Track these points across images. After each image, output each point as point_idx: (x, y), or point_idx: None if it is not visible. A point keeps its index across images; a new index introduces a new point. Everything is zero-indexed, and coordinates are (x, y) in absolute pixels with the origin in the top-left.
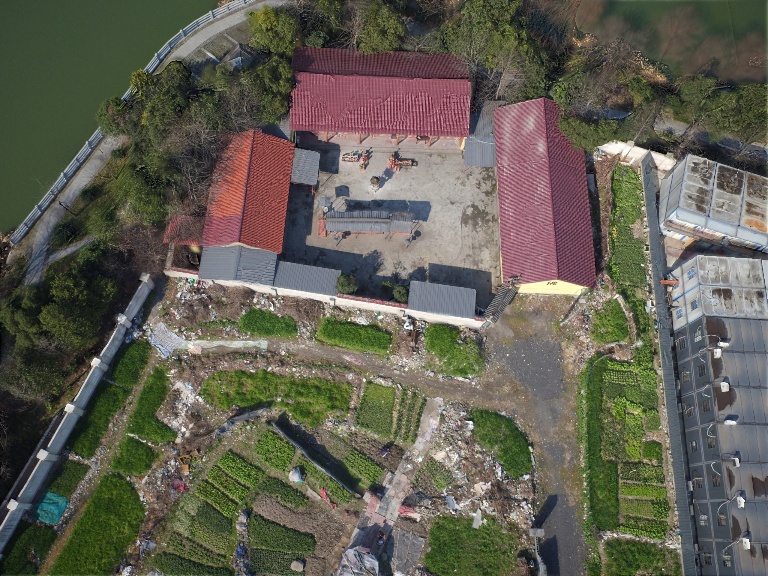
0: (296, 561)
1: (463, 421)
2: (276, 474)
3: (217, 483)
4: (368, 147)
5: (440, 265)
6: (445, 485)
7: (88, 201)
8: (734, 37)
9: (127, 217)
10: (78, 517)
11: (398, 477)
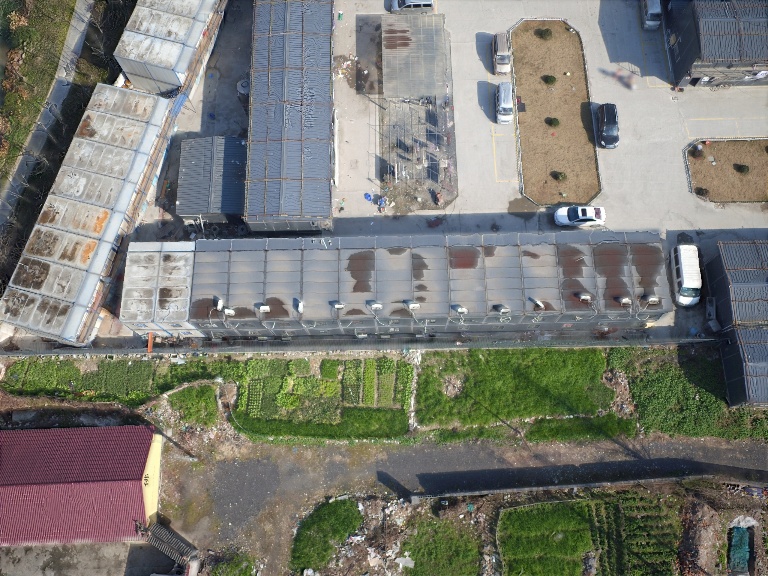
0: None
1: None
2: None
3: None
4: None
5: None
6: None
7: None
8: None
9: None
10: None
11: None
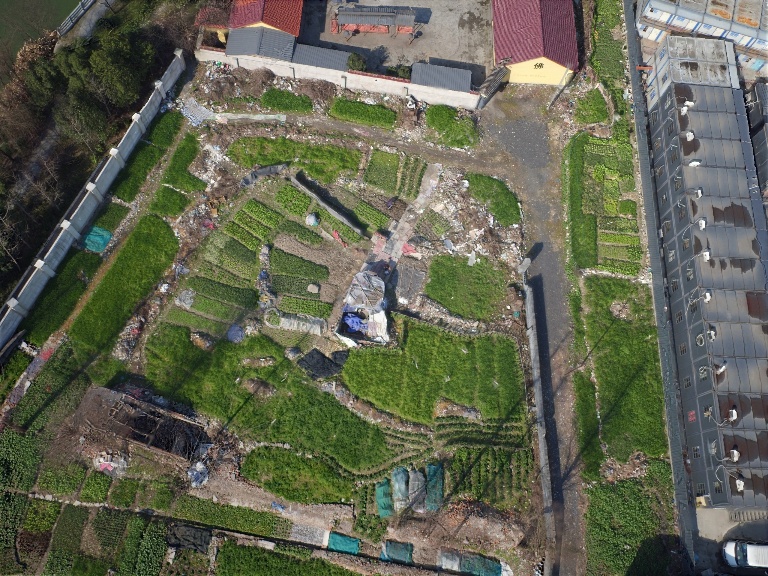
0: (312, 284)
1: (459, 181)
2: (294, 219)
3: (242, 223)
4: None
5: (440, 59)
6: (443, 231)
7: (126, 2)
8: None
9: None
10: (121, 248)
11: (402, 224)
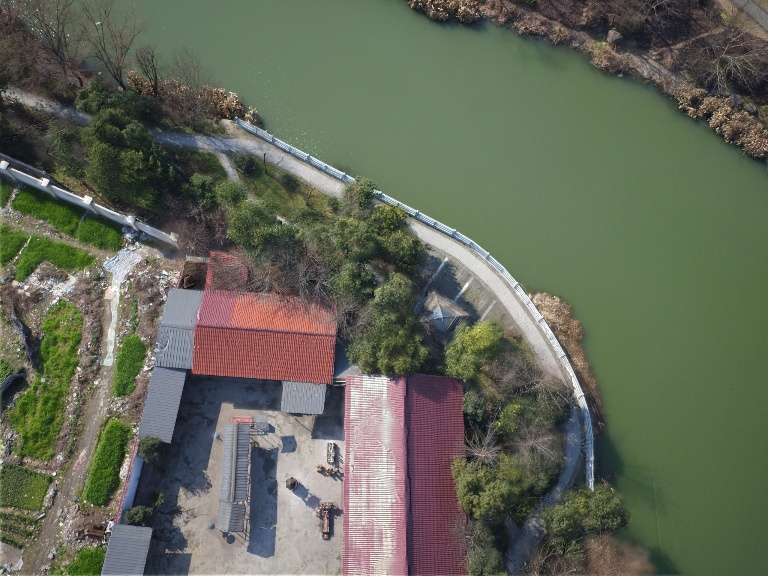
0: None
1: None
2: None
3: None
4: None
5: (188, 569)
6: None
7: None
8: None
9: (233, 214)
10: None
11: None
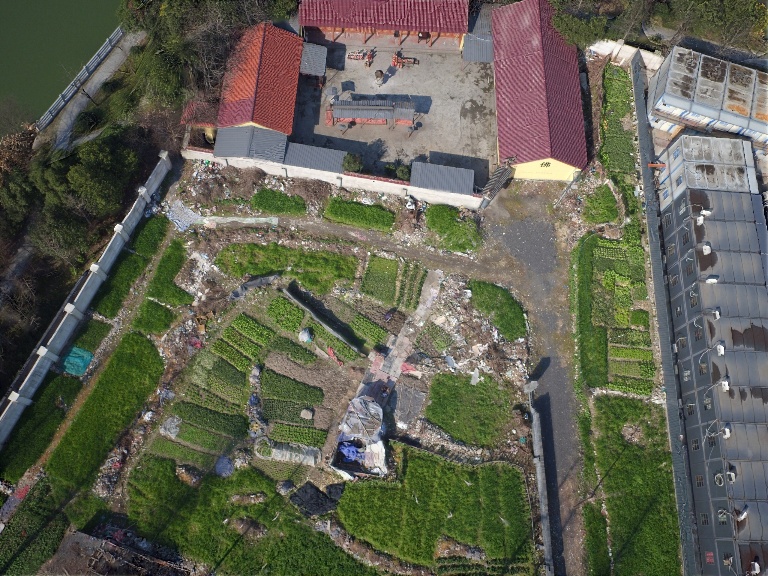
0: (306, 410)
1: (462, 290)
2: (287, 335)
3: (231, 341)
4: (372, 47)
5: (440, 153)
6: (445, 347)
7: (109, 93)
8: None
9: (147, 98)
10: (102, 370)
11: (401, 339)
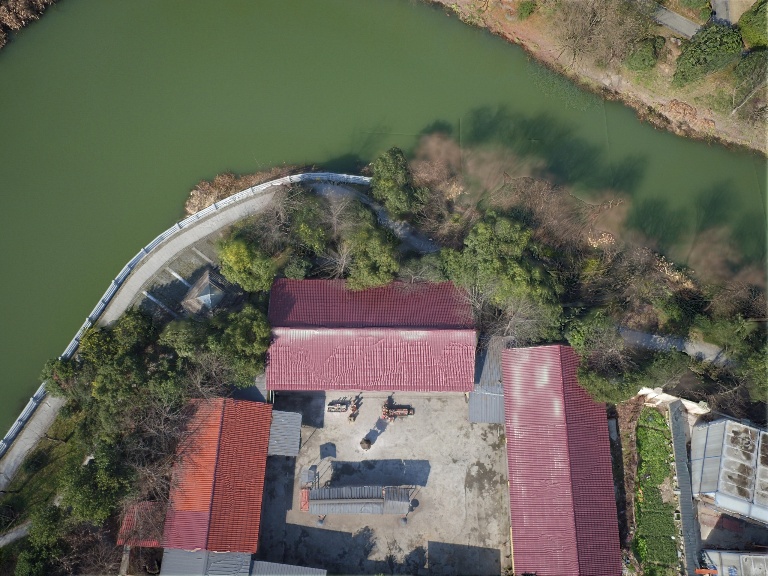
0: None
1: None
2: None
3: None
4: (358, 392)
5: (441, 543)
6: None
7: (32, 471)
8: (767, 229)
9: (73, 519)
10: None
11: None
